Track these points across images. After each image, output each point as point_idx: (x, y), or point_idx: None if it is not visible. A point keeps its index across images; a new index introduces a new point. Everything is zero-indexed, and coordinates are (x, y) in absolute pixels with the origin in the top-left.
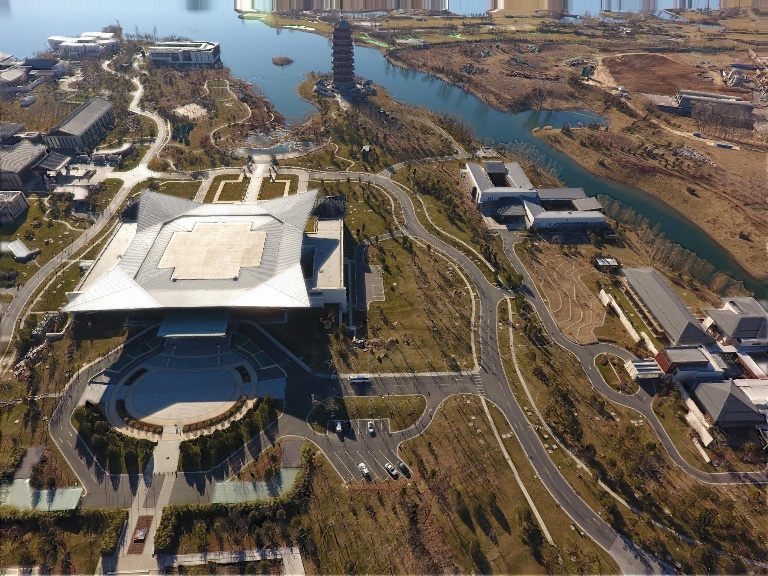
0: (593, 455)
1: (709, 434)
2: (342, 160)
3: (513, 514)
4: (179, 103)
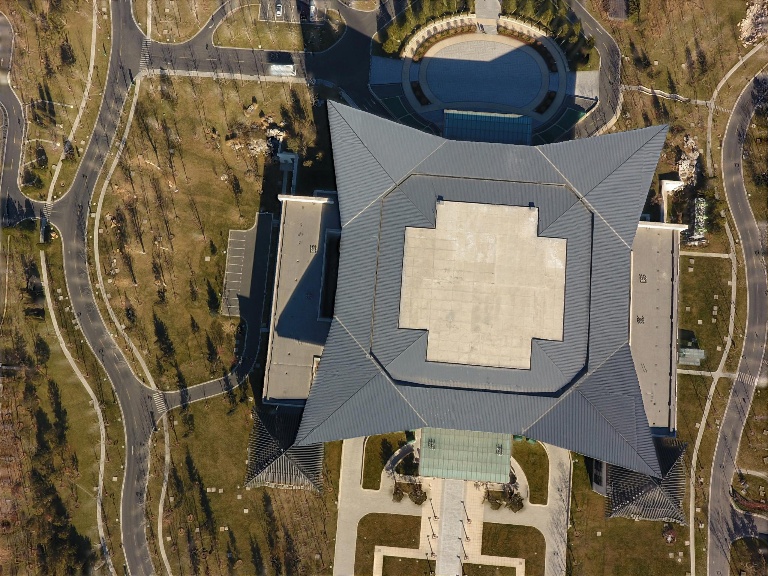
0: None
1: None
2: None
3: None
4: None
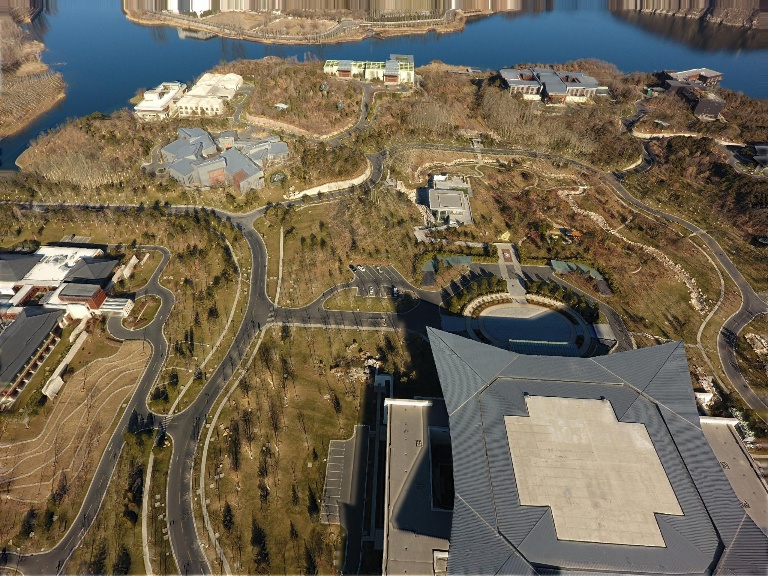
0: (226, 255)
1: (133, 257)
2: None
3: (295, 243)
4: None
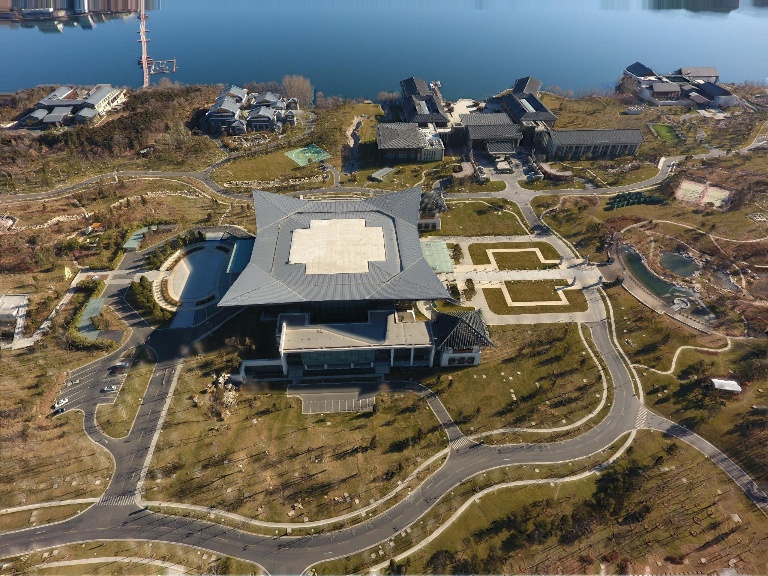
0: None
1: None
2: (667, 356)
3: None
4: (717, 182)
